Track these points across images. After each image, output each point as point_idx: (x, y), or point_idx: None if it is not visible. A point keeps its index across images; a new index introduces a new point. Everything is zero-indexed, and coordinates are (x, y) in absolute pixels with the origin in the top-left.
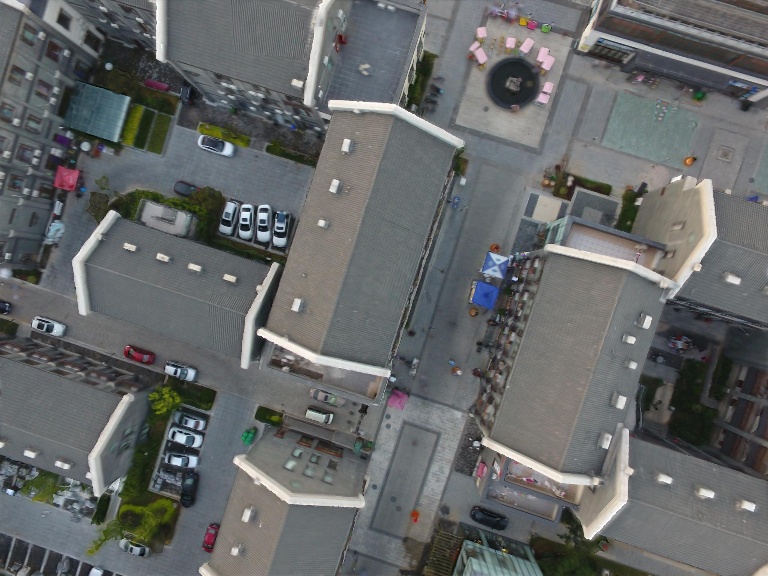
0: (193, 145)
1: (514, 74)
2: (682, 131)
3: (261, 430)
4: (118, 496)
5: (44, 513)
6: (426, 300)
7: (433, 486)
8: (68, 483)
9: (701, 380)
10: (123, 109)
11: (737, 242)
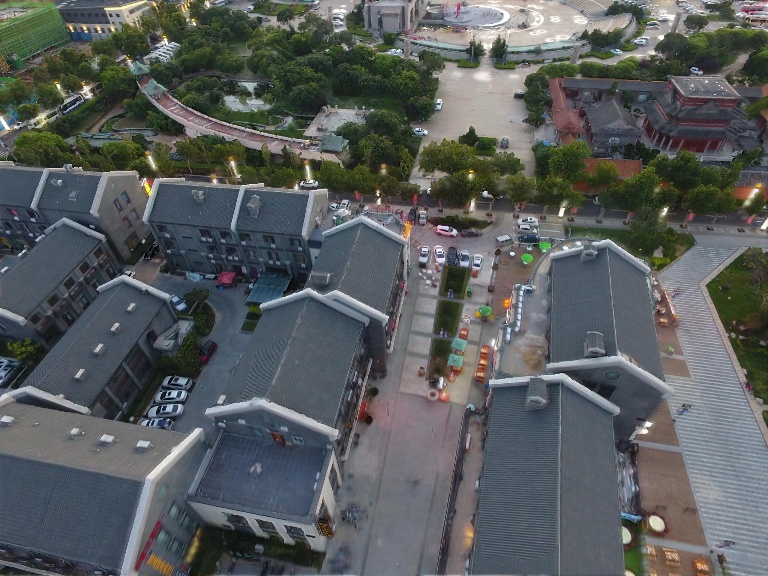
0: None
1: None
2: None
3: None
4: None
5: None
6: None
7: None
8: None
9: None
10: None
11: None
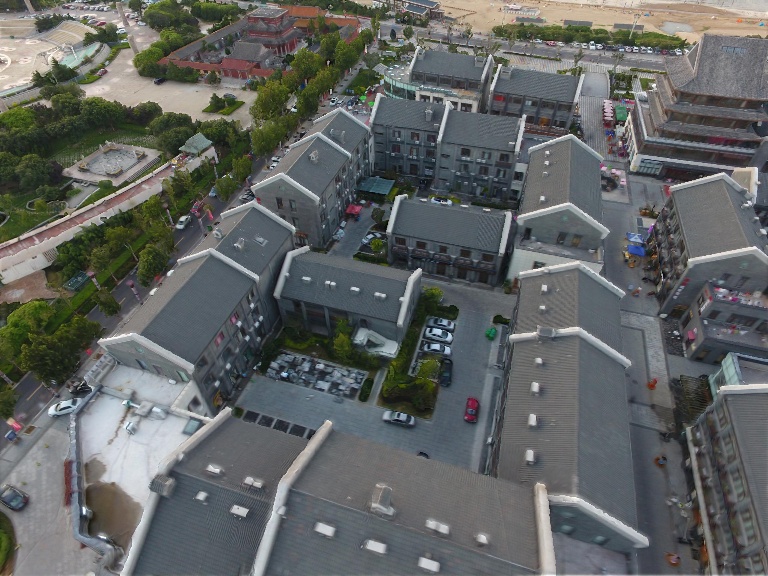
0: None
1: None
2: None
3: (500, 330)
4: (380, 381)
5: (309, 397)
6: None
7: (656, 365)
8: (356, 343)
9: None
10: (391, 184)
11: None
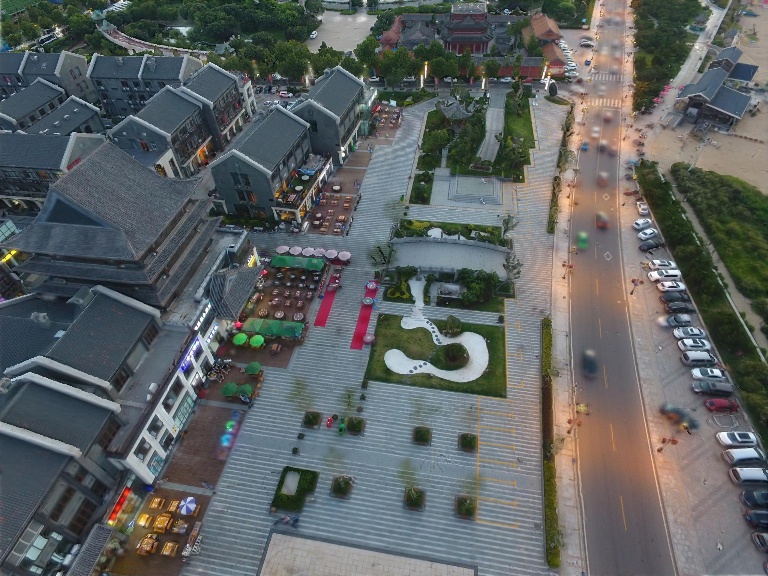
0: None
1: None
2: None
3: None
4: None
5: None
6: (21, 219)
7: None
8: None
9: None
10: None
11: None
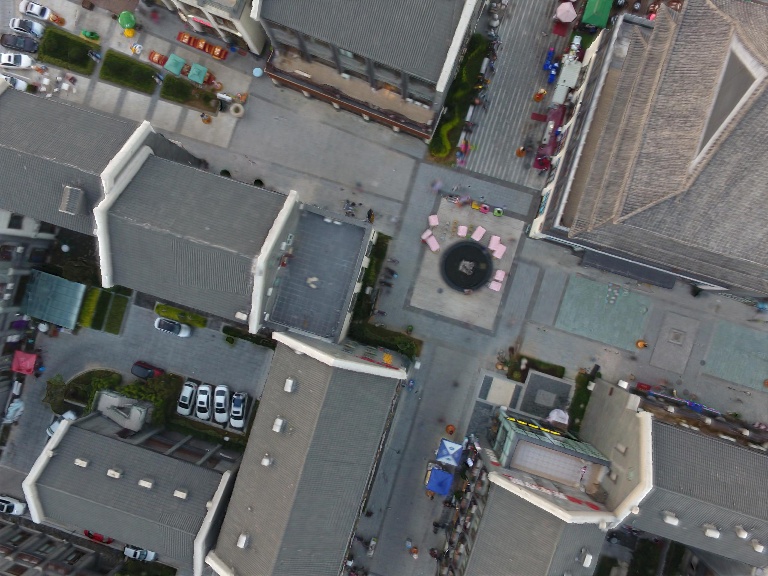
0: (150, 325)
1: (467, 257)
2: (634, 314)
3: None
4: None
5: None
6: (383, 480)
7: None
8: None
9: (654, 562)
10: (78, 297)
11: (674, 487)
